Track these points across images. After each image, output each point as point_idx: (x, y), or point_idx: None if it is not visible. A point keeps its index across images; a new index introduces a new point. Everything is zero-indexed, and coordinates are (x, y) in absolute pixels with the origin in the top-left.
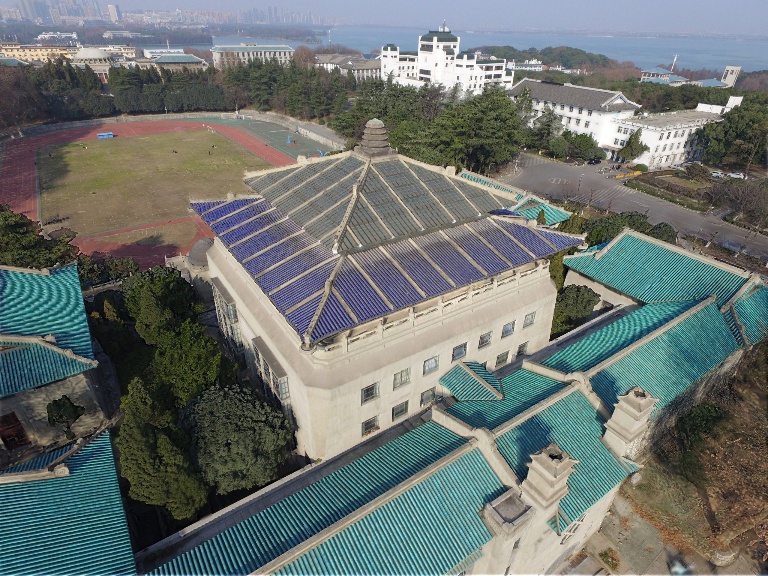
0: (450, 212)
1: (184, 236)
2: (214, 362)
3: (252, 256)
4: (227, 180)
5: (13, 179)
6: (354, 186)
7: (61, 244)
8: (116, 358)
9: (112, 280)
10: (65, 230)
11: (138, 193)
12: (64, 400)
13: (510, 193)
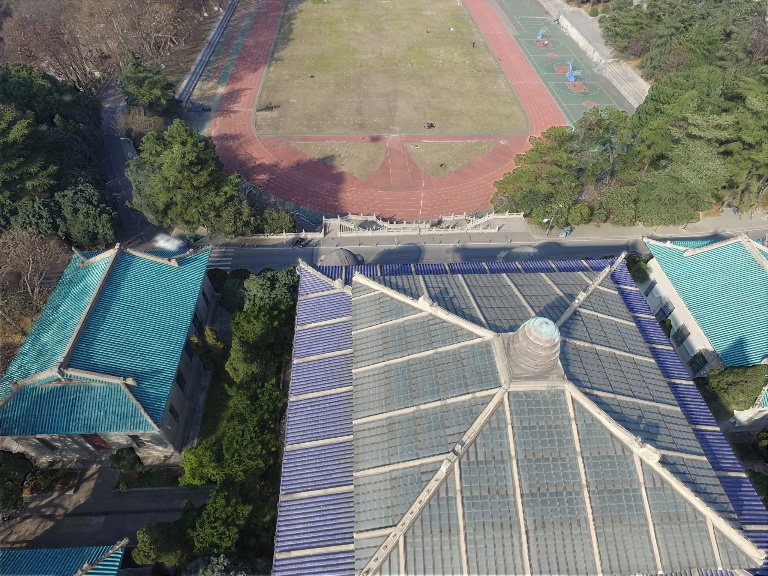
0: (601, 551)
1: (369, 164)
2: (241, 515)
3: (299, 445)
4: (444, 88)
5: (255, 40)
6: (445, 463)
7: (230, 185)
8: (214, 371)
9: (266, 233)
10: (247, 156)
11: (350, 87)
12: (125, 455)
13: (752, 547)
